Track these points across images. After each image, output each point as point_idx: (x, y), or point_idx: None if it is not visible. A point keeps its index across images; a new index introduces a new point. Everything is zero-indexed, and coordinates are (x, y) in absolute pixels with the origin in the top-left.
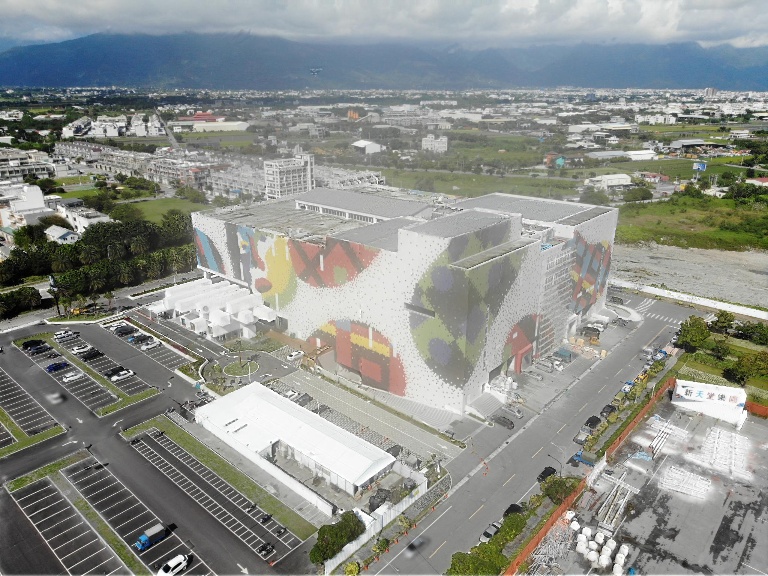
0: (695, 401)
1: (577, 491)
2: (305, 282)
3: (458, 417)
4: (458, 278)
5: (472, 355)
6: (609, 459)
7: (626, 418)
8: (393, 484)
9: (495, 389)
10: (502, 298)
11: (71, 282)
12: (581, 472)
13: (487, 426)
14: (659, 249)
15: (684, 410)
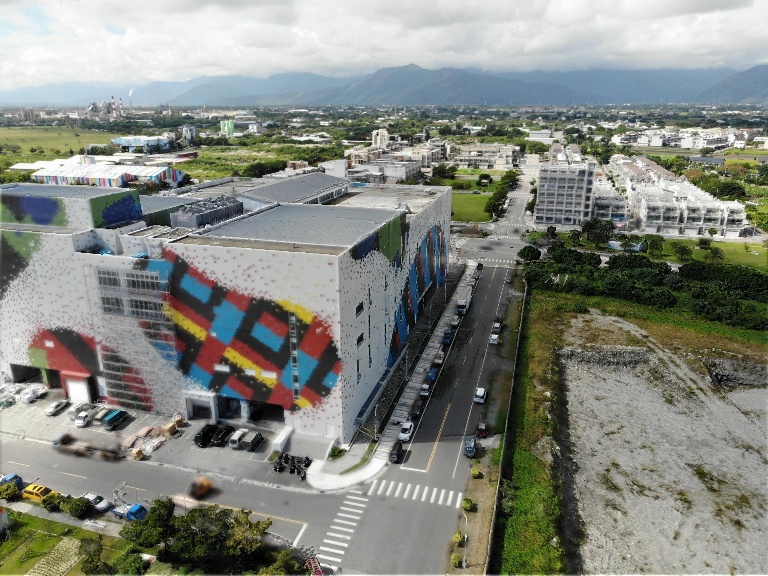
0: None
1: None
2: None
3: None
4: None
5: None
6: None
7: None
8: None
9: (10, 385)
10: (6, 282)
11: None
12: None
13: None
14: None
15: None
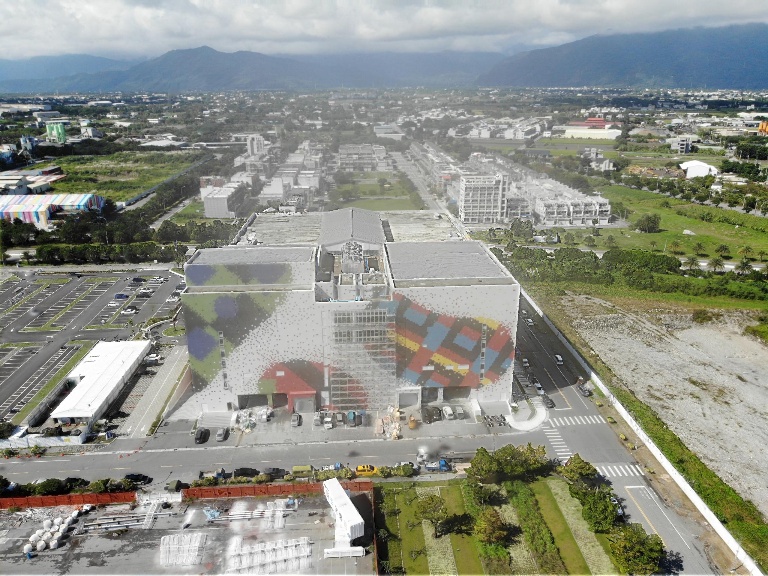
0: None
1: (120, 498)
2: None
3: (193, 418)
4: None
5: (203, 370)
6: (188, 499)
7: None
8: None
9: (240, 412)
10: (245, 331)
11: None
12: None
13: None
14: None
15: (331, 513)
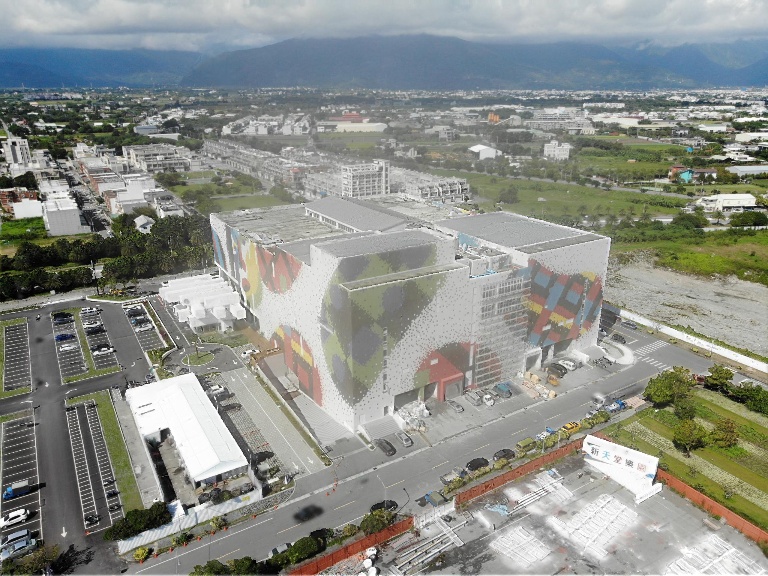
0: (603, 462)
1: (396, 530)
2: (266, 286)
3: (349, 435)
4: (344, 298)
5: (364, 376)
6: (460, 505)
7: (517, 466)
8: (238, 486)
9: (400, 413)
10: (408, 322)
11: (119, 266)
12: (422, 512)
13: (368, 449)
14: (735, 285)
15: (592, 470)
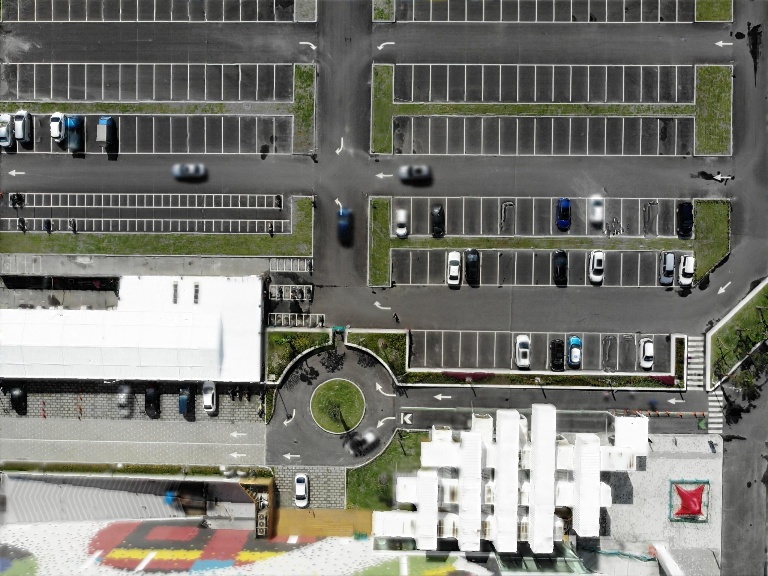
0: None
1: None
2: None
3: (7, 517)
4: None
5: None
6: None
7: None
8: None
9: None
10: None
11: None
12: None
13: None
14: None
15: None
